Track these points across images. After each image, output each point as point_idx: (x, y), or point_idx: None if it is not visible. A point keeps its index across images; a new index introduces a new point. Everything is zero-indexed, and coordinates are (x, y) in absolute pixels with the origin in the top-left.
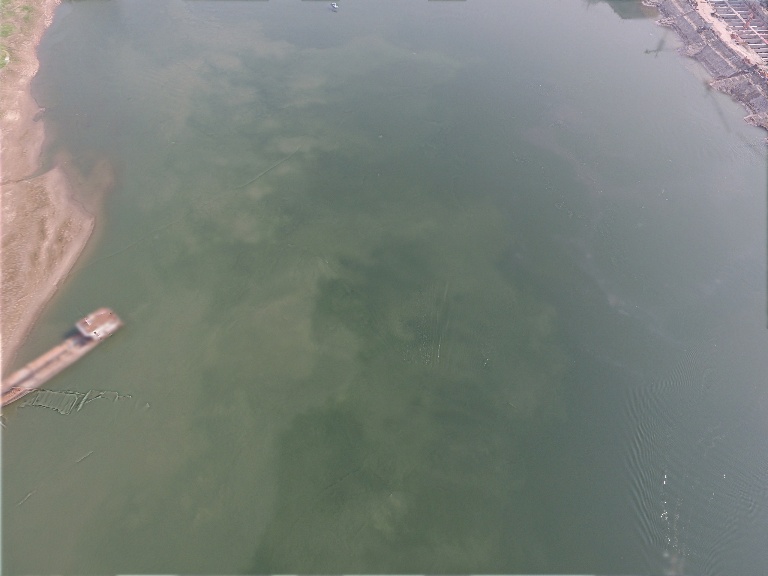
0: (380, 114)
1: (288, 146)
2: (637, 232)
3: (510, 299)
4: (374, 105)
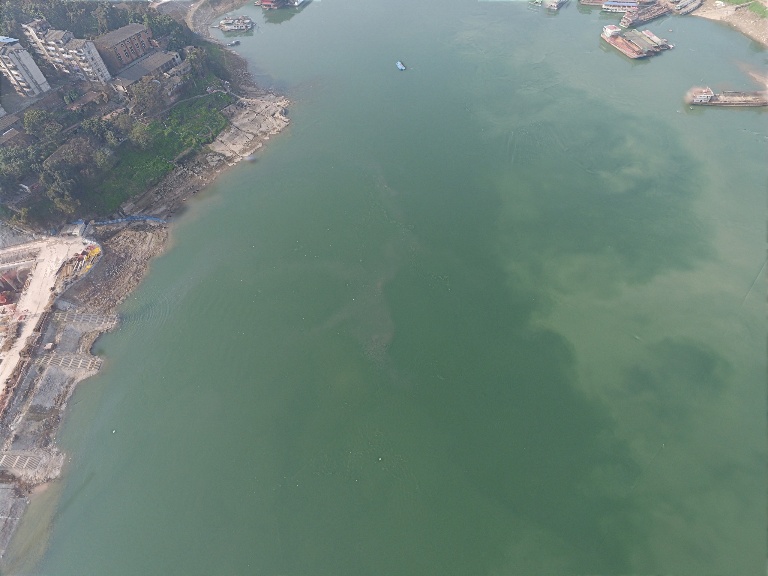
0: (659, 366)
1: (761, 308)
2: (347, 207)
3: (465, 155)
4: (685, 412)
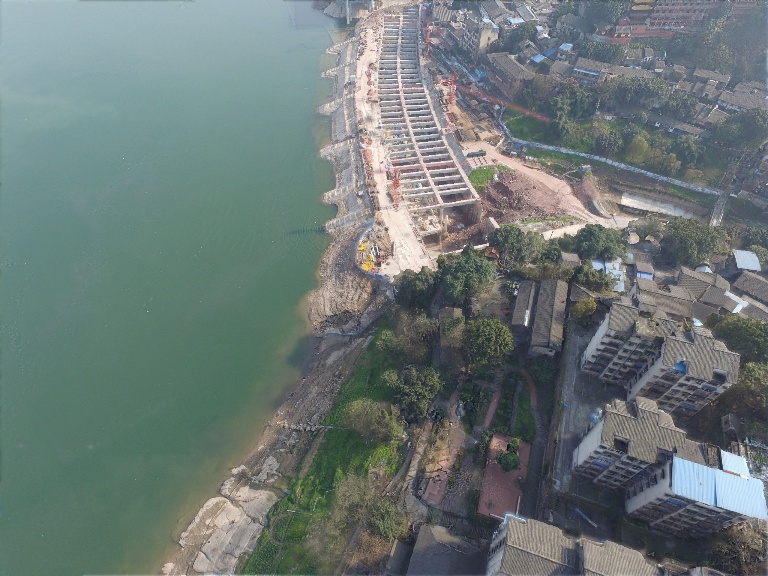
0: None
1: None
2: (69, 363)
3: None
4: None
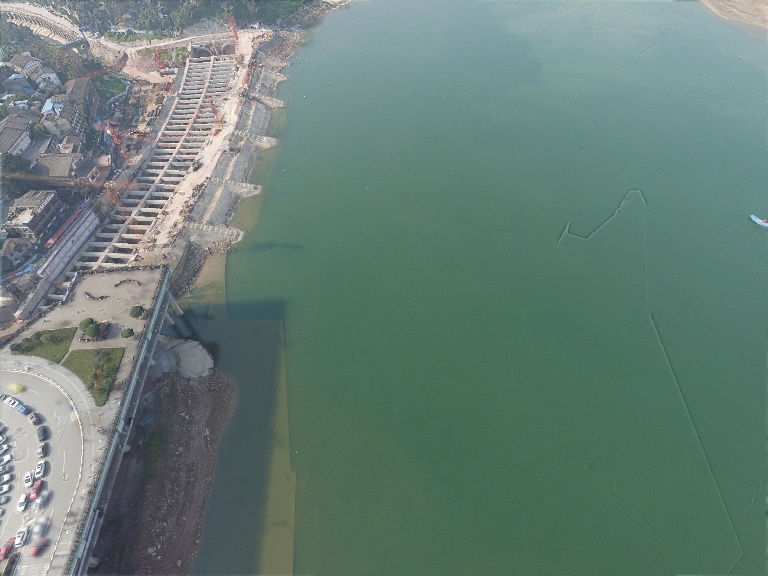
0: None
1: (646, 56)
2: (412, 24)
3: None
4: None
